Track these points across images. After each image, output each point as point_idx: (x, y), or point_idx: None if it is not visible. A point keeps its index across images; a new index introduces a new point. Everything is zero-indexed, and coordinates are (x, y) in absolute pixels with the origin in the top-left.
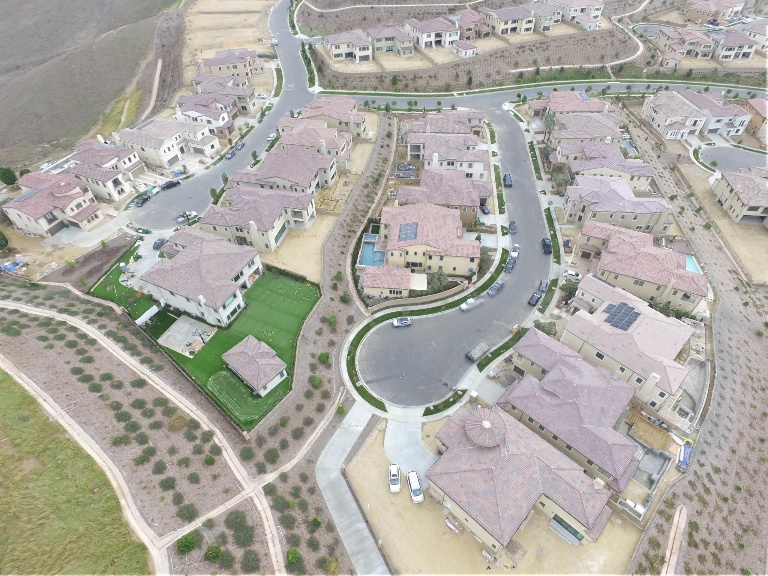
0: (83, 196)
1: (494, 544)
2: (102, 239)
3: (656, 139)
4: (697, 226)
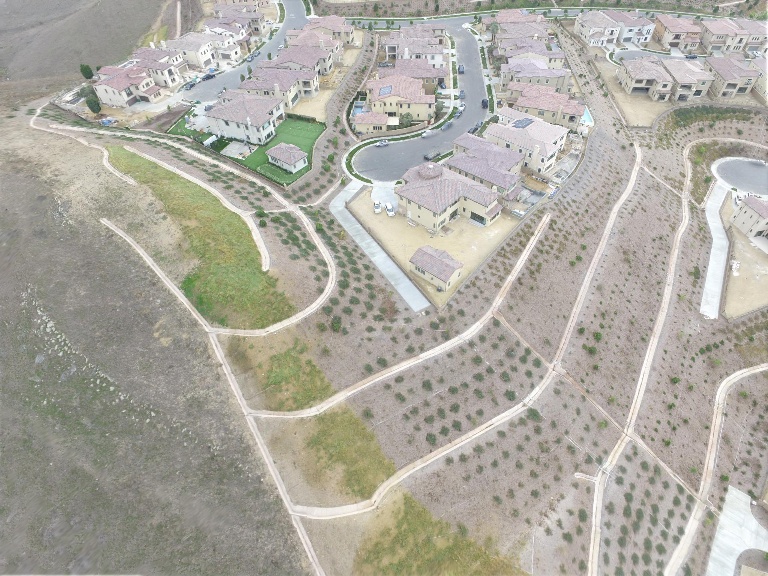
0: (150, 78)
1: (434, 223)
2: (166, 107)
3: (582, 46)
4: (597, 94)
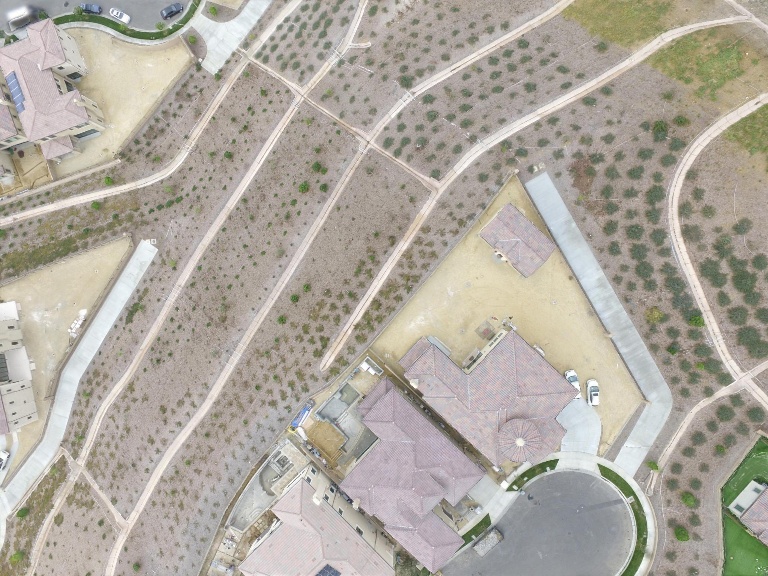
0: None
1: None
2: None
3: None
4: None
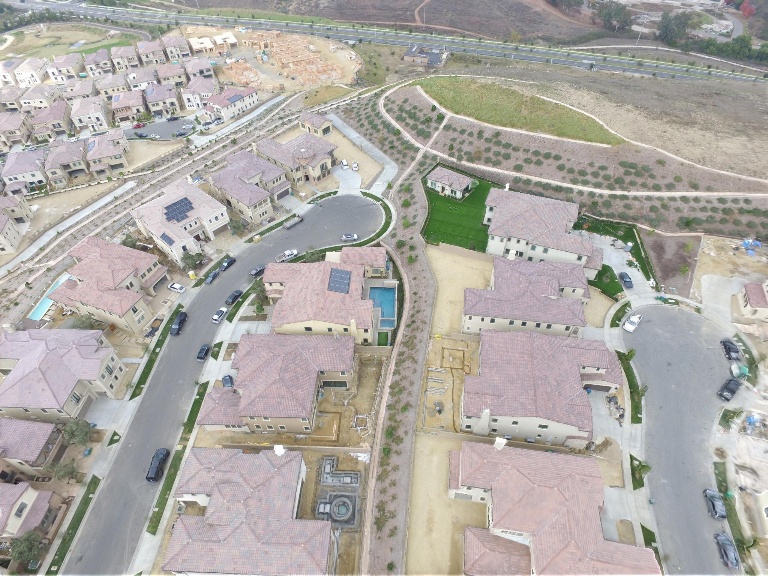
0: None
1: None
2: None
3: None
4: None
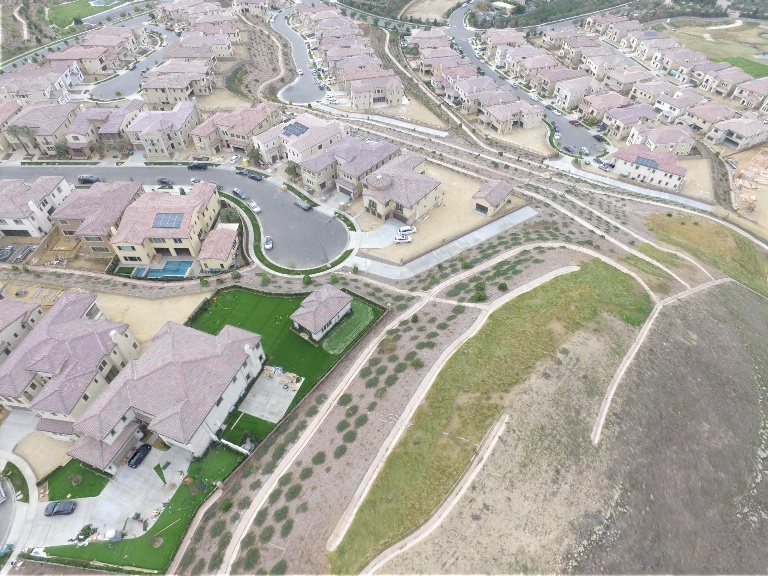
0: None
1: None
2: None
3: None
4: None
